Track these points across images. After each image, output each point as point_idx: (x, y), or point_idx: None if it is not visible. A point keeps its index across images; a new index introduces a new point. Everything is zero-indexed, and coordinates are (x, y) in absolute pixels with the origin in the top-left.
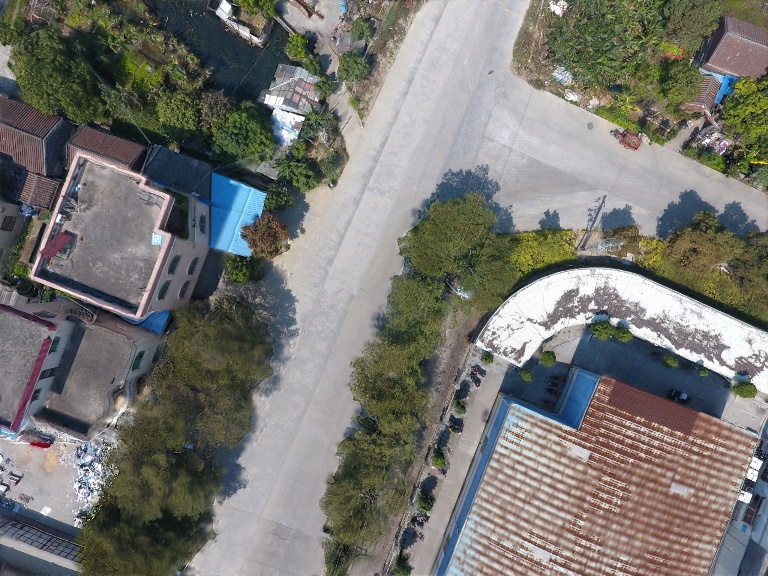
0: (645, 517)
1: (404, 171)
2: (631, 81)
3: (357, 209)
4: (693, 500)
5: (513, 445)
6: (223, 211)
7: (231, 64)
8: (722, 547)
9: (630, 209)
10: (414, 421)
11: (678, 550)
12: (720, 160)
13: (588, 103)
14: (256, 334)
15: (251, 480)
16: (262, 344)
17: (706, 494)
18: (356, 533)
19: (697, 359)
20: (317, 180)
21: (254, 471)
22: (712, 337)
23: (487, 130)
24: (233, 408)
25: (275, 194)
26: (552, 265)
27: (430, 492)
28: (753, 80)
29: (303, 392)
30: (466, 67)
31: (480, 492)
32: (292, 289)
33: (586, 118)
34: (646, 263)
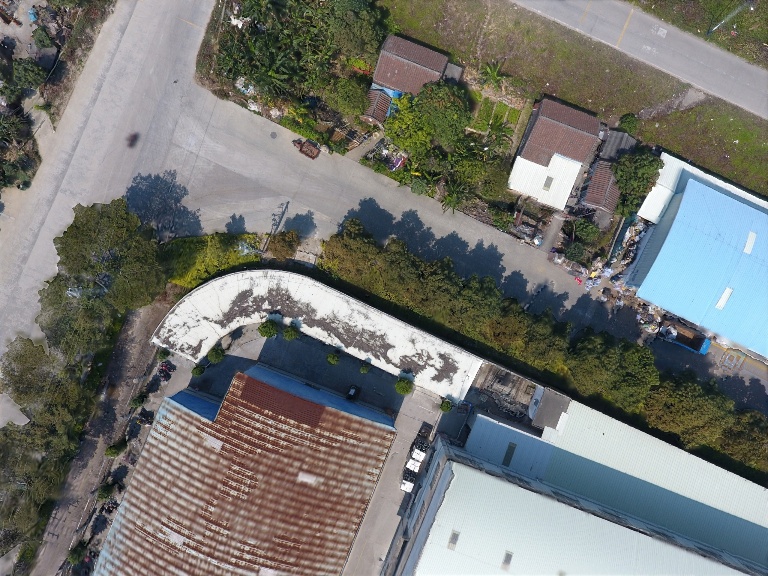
0: (272, 504)
1: (95, 174)
2: (322, 93)
3: (50, 210)
4: (323, 488)
5: (161, 436)
6: None
7: None
8: (396, 533)
9: (312, 215)
10: (66, 413)
11: (309, 535)
12: (401, 170)
13: (270, 113)
14: None
15: None
16: None
17: (338, 483)
18: (8, 518)
19: (365, 357)
20: None
21: None
22: (378, 337)
23: (174, 137)
24: None
25: None
26: (236, 267)
27: (121, 481)
28: (411, 96)
29: None
30: (152, 76)
31: (131, 480)
32: None
33: (269, 128)
34: (325, 266)
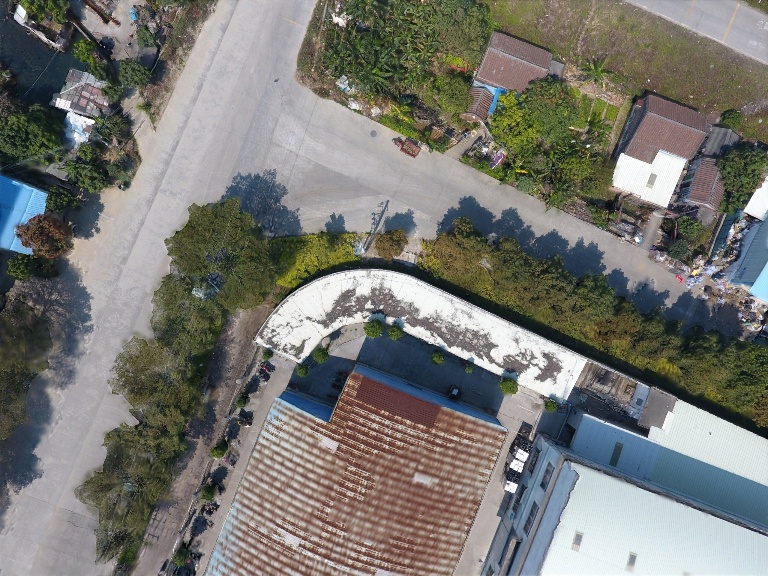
0: (389, 505)
1: (195, 174)
2: (419, 91)
3: (150, 210)
4: (438, 489)
5: (273, 437)
6: (5, 211)
7: (33, 67)
8: (497, 534)
9: (412, 213)
10: (178, 414)
11: (424, 536)
12: (500, 168)
13: (370, 112)
14: (33, 330)
15: (47, 470)
16: (39, 339)
17: (452, 483)
18: (121, 520)
19: (468, 357)
20: (103, 182)
21: (49, 461)
22: (481, 336)
23: (274, 136)
24: (3, 400)
25: (55, 195)
26: (336, 266)
27: (220, 482)
28: (516, 93)
29: (97, 386)
30: (253, 75)
31: (243, 481)
32: (87, 286)
33: (369, 126)
34: (426, 265)
